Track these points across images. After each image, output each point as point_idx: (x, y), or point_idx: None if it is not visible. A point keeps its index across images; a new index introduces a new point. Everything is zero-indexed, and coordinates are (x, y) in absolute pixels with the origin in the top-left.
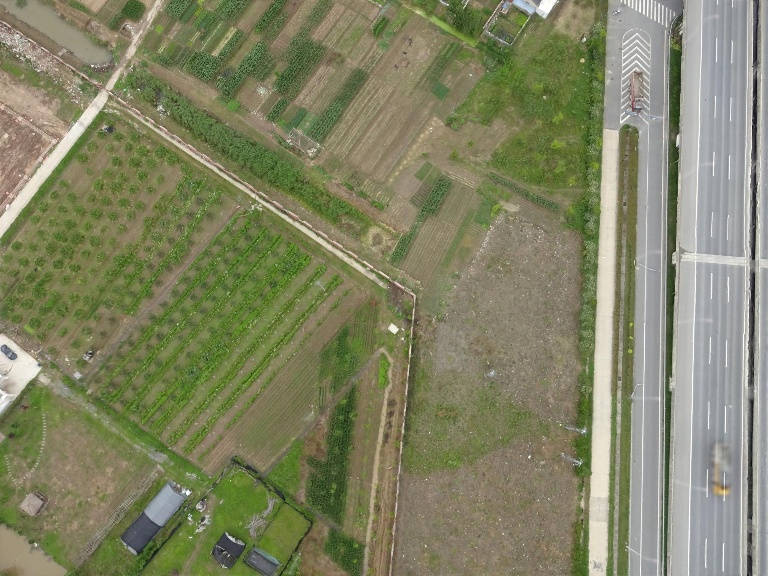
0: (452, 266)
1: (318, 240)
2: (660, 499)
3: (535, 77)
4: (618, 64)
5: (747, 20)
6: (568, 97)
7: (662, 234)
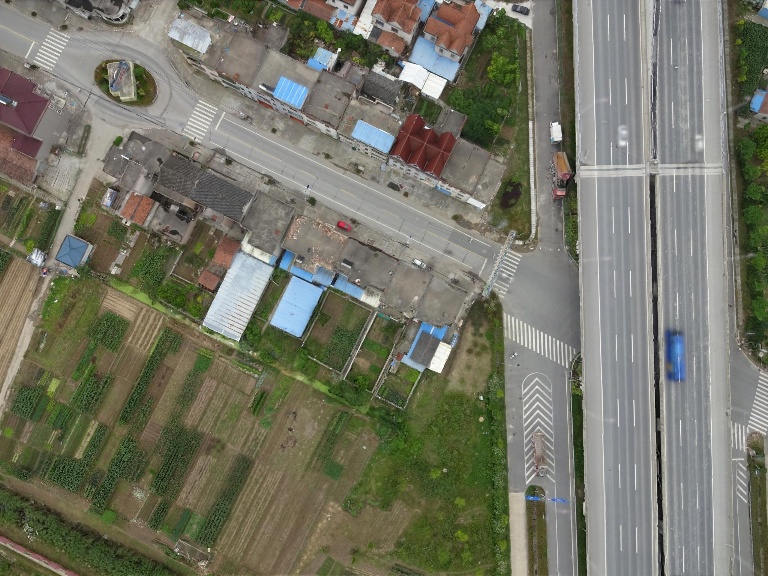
0: None
1: None
2: None
3: (433, 450)
4: (519, 417)
5: (648, 376)
6: (469, 468)
7: None
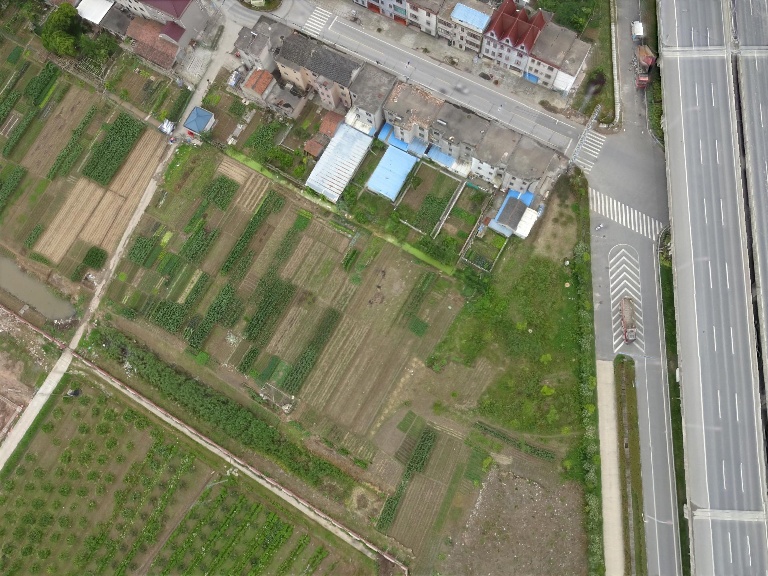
0: (444, 530)
1: (299, 507)
2: None
3: (518, 309)
4: (606, 285)
5: (740, 239)
6: (555, 330)
7: (670, 480)
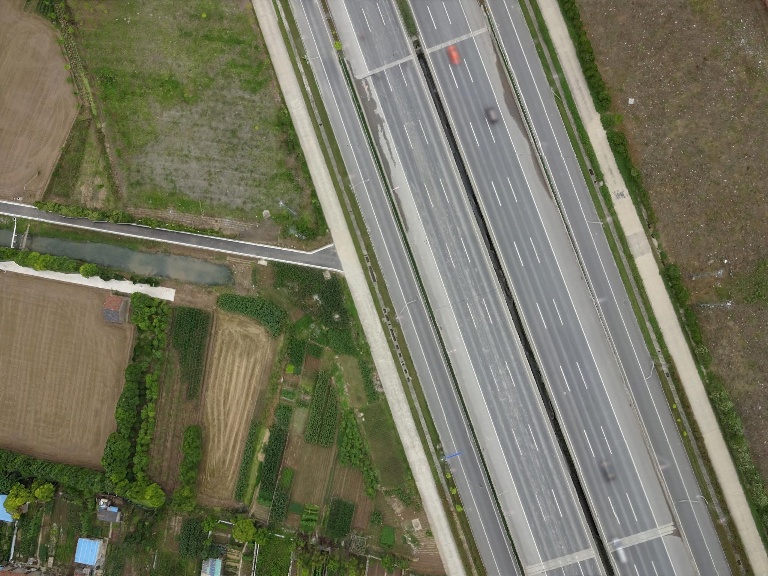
0: None
1: None
2: (589, 279)
3: None
4: None
5: None
6: None
7: (689, 545)
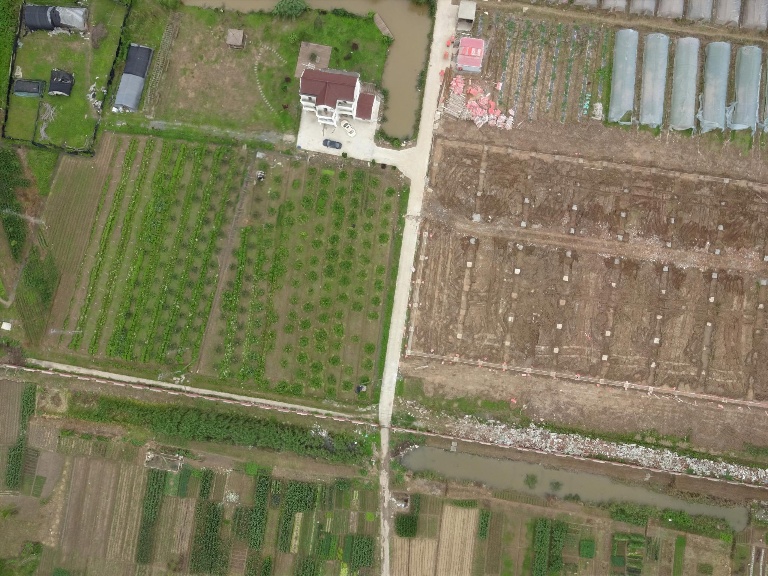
0: None
1: (108, 374)
2: None
3: None
4: None
5: None
6: None
7: None
